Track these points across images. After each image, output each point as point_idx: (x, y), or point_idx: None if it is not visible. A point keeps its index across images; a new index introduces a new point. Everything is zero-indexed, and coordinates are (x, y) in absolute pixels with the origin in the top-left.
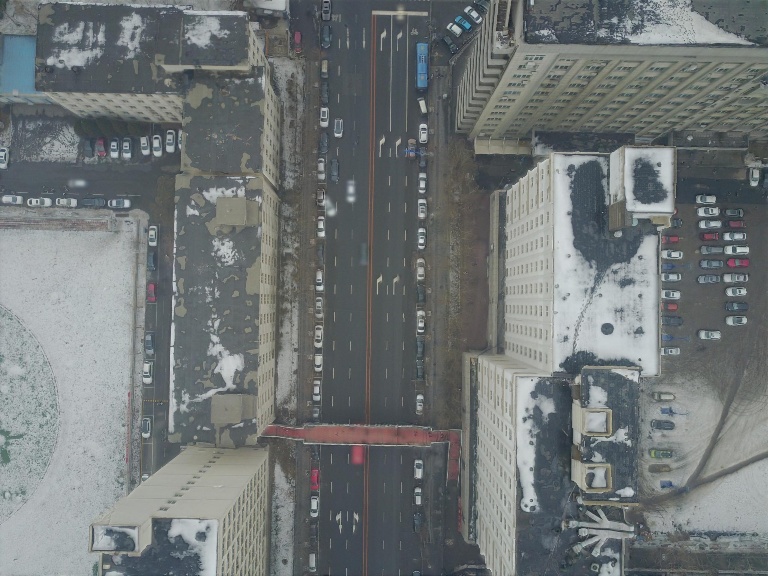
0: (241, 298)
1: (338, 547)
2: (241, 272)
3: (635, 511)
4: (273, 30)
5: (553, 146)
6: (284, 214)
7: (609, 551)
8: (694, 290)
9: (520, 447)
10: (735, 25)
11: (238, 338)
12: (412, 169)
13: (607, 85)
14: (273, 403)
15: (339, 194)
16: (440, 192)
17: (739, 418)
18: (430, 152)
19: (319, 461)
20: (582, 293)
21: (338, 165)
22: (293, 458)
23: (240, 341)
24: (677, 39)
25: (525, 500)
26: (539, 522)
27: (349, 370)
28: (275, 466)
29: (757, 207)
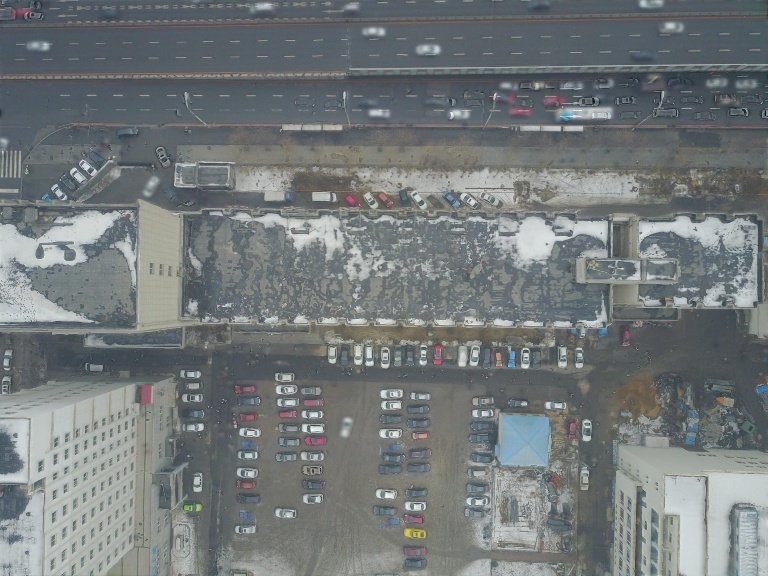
0: None
1: None
2: None
3: None
4: None
5: (103, 337)
6: None
7: None
8: (273, 467)
9: None
10: (74, 304)
11: None
12: (0, 346)
13: None
14: None
15: None
16: None
17: None
18: None
19: None
20: None
21: None
22: None
23: None
24: (17, 318)
25: None
26: None
27: None
28: None
29: (337, 384)
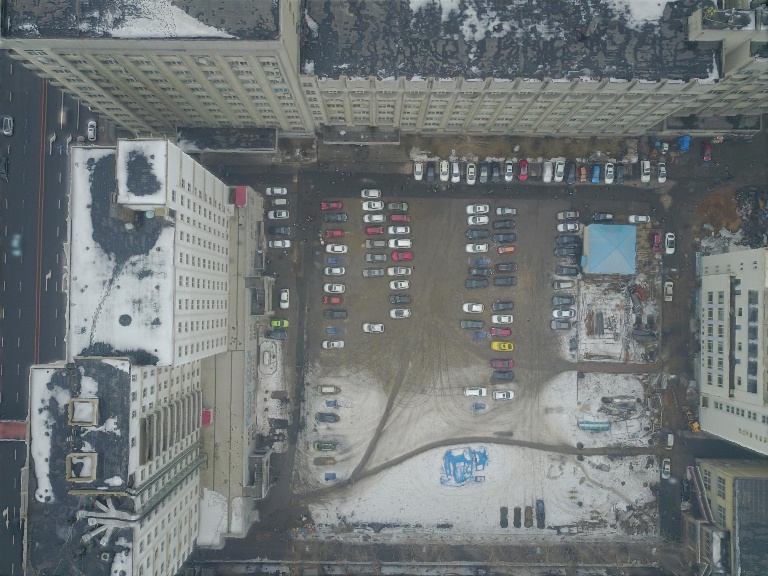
0: None
1: (5, 542)
2: None
3: (300, 504)
4: None
5: (196, 142)
6: None
7: (123, 540)
8: (360, 284)
9: (35, 438)
10: (215, 19)
11: None
12: None
13: (164, 80)
14: None
15: (8, 192)
16: None
17: (404, 410)
18: None
19: None
20: (100, 285)
21: (7, 163)
22: None
23: None
24: (158, 33)
25: (40, 491)
26: (54, 512)
27: (17, 366)
28: None
29: (423, 201)
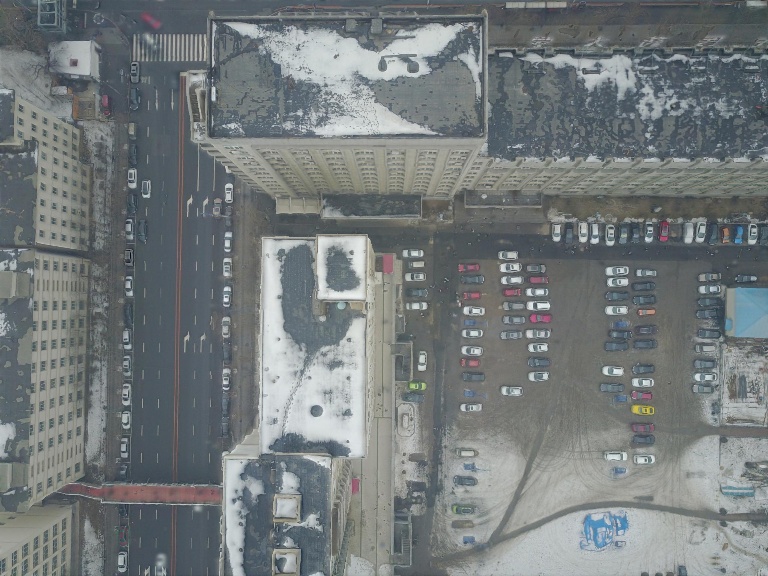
0: (13, 368)
1: None
2: (13, 343)
3: (438, 567)
4: (84, 93)
5: (341, 208)
6: (94, 274)
7: None
8: (497, 346)
9: (230, 528)
10: (418, 115)
11: (10, 407)
12: (219, 228)
13: None
14: (82, 460)
15: (147, 254)
16: (246, 251)
17: (542, 474)
18: (236, 211)
19: (128, 517)
20: (292, 376)
21: (146, 225)
22: (102, 514)
23: (12, 410)
24: (361, 130)
25: None
26: None
27: (157, 427)
28: (85, 522)
29: (560, 262)
